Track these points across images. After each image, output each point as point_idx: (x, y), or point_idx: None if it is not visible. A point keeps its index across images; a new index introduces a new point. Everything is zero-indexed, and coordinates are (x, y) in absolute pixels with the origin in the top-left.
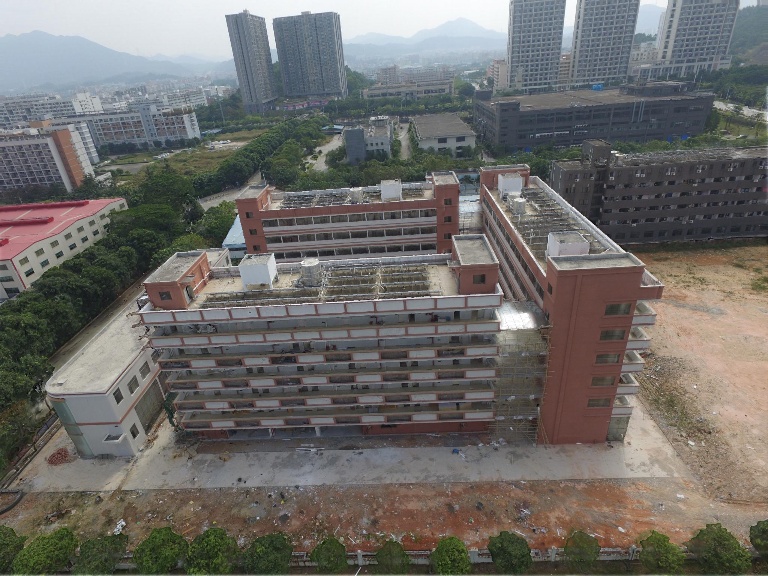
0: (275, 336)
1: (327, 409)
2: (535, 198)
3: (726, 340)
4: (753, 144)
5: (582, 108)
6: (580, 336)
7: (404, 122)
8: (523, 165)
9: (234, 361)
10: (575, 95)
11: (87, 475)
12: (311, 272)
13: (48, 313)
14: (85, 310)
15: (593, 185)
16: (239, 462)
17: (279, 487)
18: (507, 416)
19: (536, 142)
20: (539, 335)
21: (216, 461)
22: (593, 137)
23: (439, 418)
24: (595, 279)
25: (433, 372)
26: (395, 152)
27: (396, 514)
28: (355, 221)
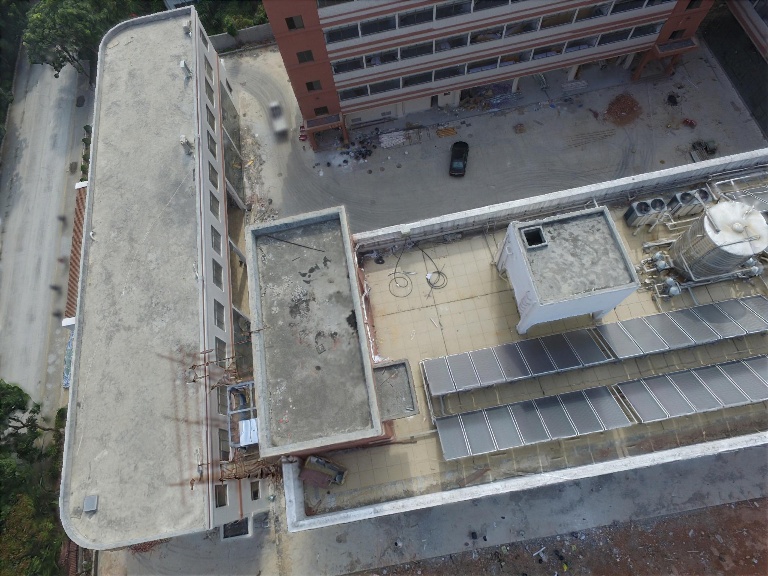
0: None
1: None
2: None
3: None
4: None
5: None
6: None
7: None
8: None
9: None
10: None
11: (213, 564)
12: (743, 261)
13: None
14: None
15: None
16: None
17: (545, 539)
18: None
19: None
20: None
21: None
22: None
23: None
24: None
25: None
26: None
27: (757, 563)
28: None
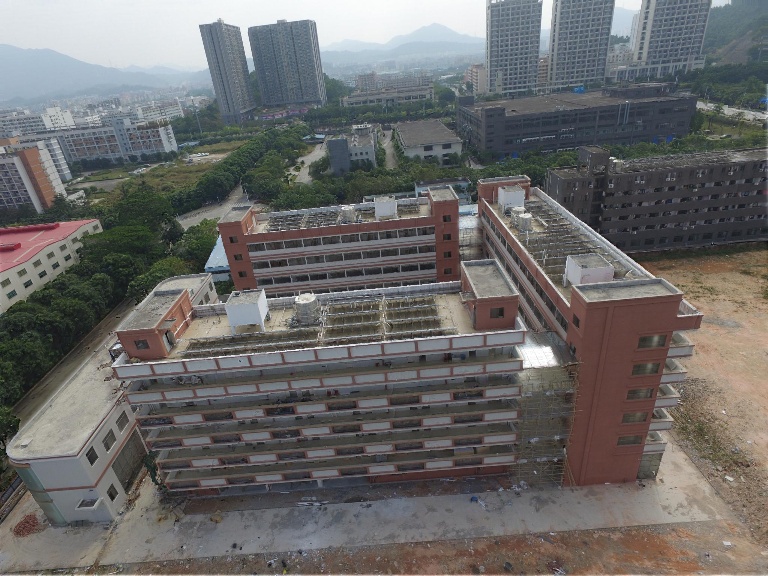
0: (270, 386)
1: (330, 461)
2: (539, 212)
3: (747, 356)
4: (739, 144)
5: (567, 112)
6: (610, 371)
7: (386, 129)
8: (522, 176)
9: (224, 414)
10: (558, 98)
11: (59, 548)
12: (307, 309)
13: (13, 354)
14: (56, 347)
15: (592, 193)
16: (233, 523)
17: (280, 553)
18: (530, 459)
19: (523, 147)
20: (566, 372)
21: (207, 523)
22: (580, 140)
23: (455, 464)
24: (628, 310)
25: (448, 416)
26: (380, 161)
27: None
28: (348, 242)
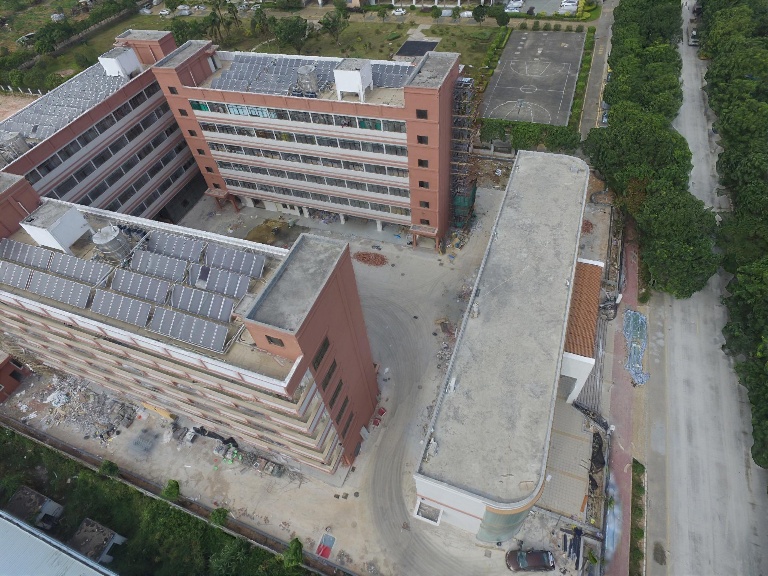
0: None
1: None
2: None
3: None
4: None
5: None
6: None
7: None
8: None
9: None
10: None
11: None
12: None
13: None
14: None
15: None
16: None
17: None
18: None
19: None
20: None
21: None
22: None
23: None
24: None
25: None
26: None
27: None
28: None
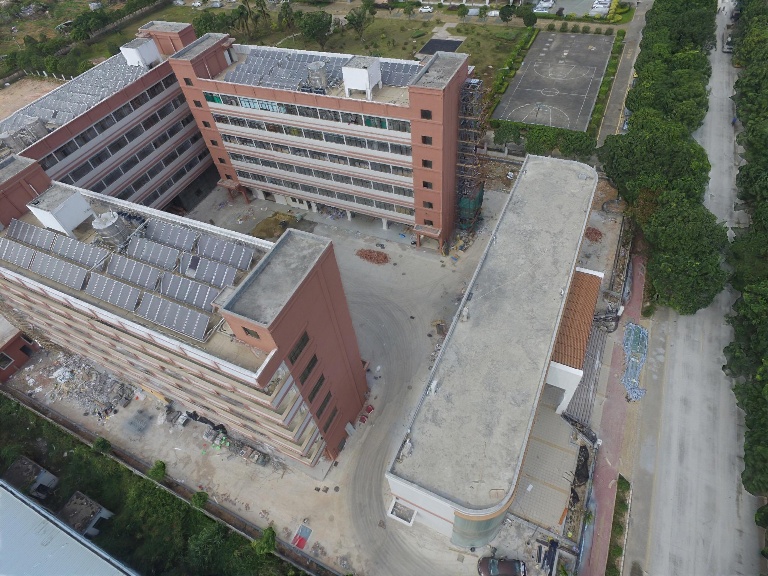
0: None
1: None
2: None
3: None
4: None
5: None
6: None
7: None
8: None
9: None
10: None
11: None
12: None
13: None
14: None
15: None
16: None
17: None
18: None
19: None
20: None
21: None
22: None
23: None
24: None
25: None
26: None
27: None
28: None
